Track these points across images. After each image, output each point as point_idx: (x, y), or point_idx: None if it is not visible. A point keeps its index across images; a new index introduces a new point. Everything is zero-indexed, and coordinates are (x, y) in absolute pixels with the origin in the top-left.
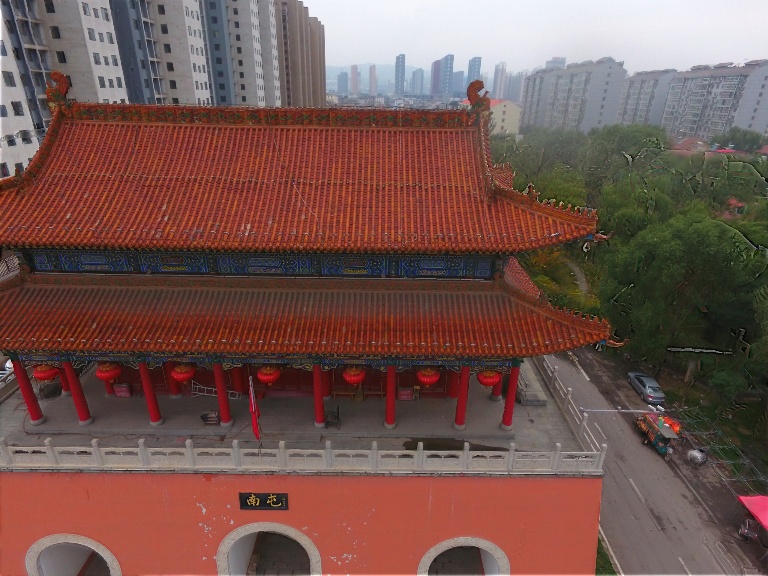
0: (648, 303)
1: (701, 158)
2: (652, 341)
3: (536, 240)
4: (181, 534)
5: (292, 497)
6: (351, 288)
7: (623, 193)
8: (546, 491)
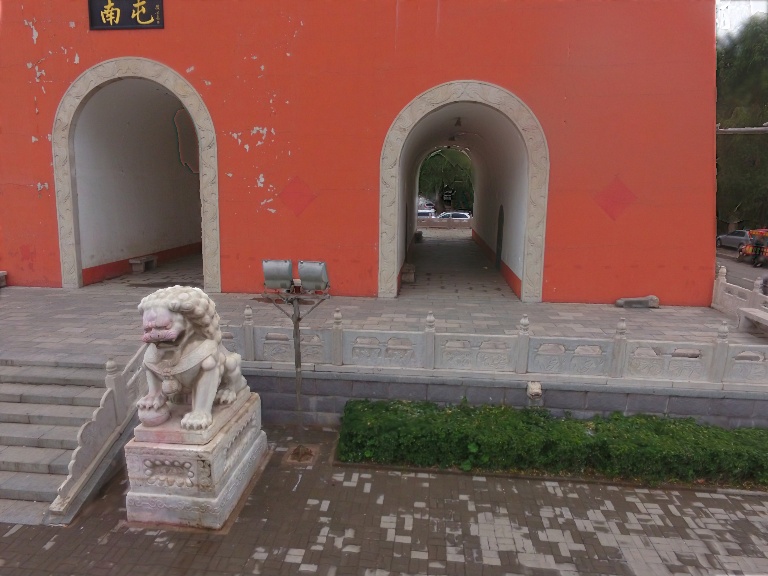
0: None
1: None
2: (747, 176)
3: None
4: (1, 87)
5: (170, 2)
6: None
7: None
8: None
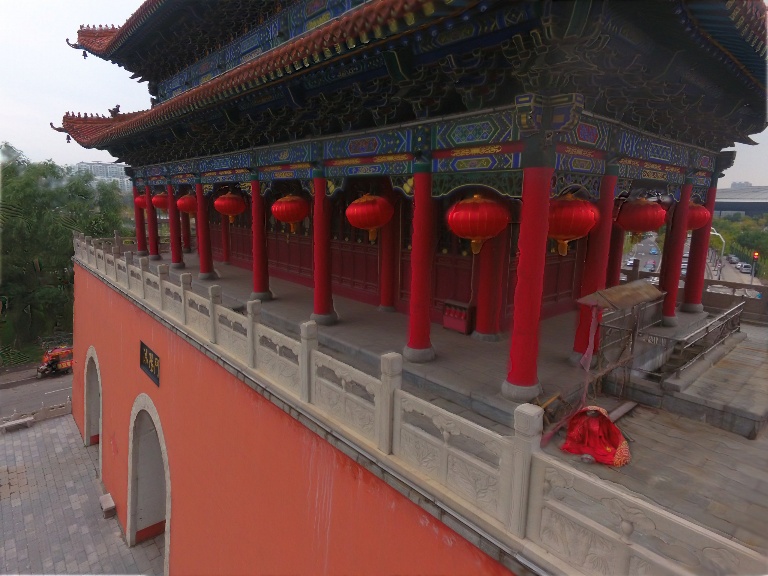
0: None
1: None
2: None
3: None
4: None
5: None
6: None
7: None
8: None
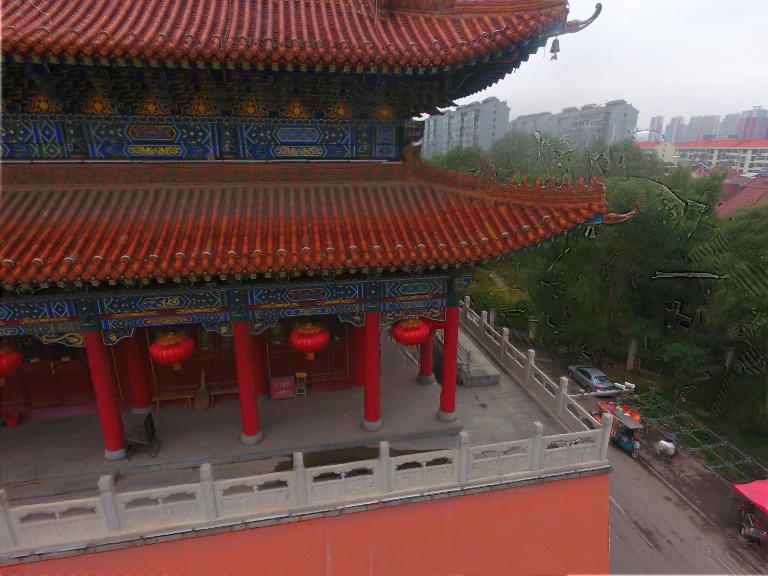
0: (583, 277)
1: (607, 132)
2: (590, 324)
3: (468, 44)
4: None
5: None
6: (150, 181)
7: (533, 182)
8: (525, 511)
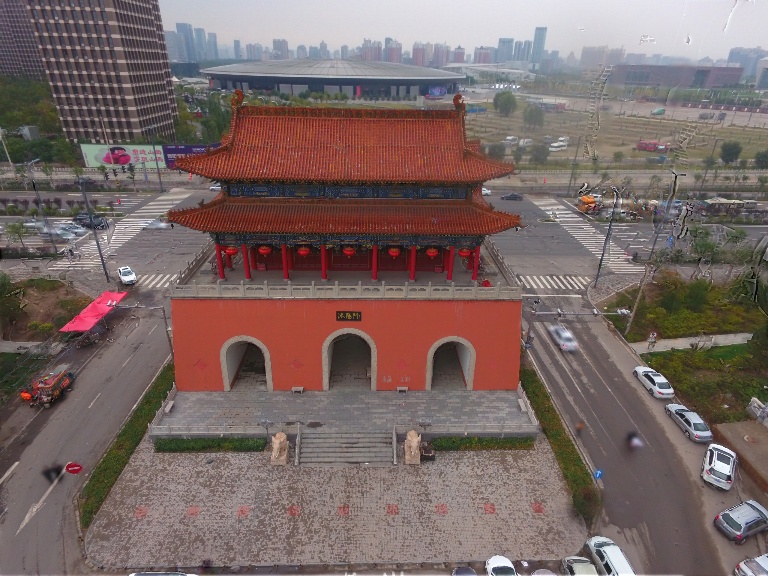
0: None
1: None
2: None
3: None
4: None
5: None
6: None
7: None
8: None
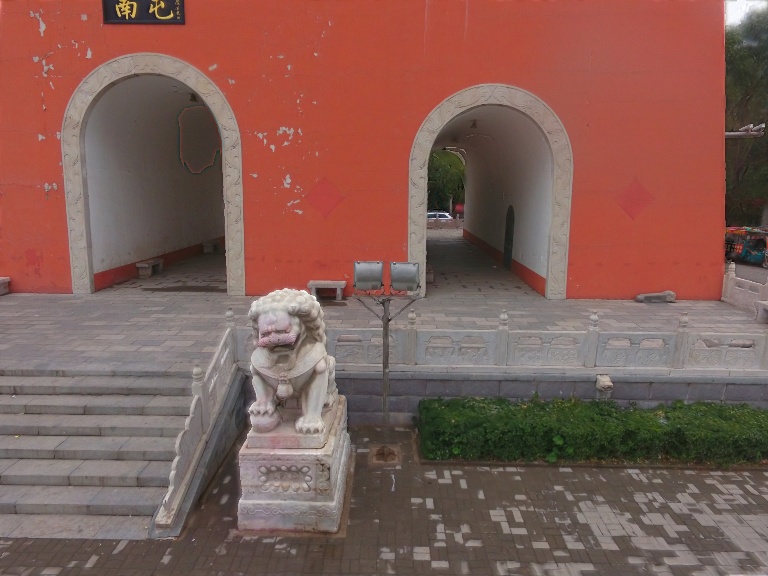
0: None
1: (737, 5)
2: None
3: None
4: (3, 82)
5: None
6: None
7: None
8: None
